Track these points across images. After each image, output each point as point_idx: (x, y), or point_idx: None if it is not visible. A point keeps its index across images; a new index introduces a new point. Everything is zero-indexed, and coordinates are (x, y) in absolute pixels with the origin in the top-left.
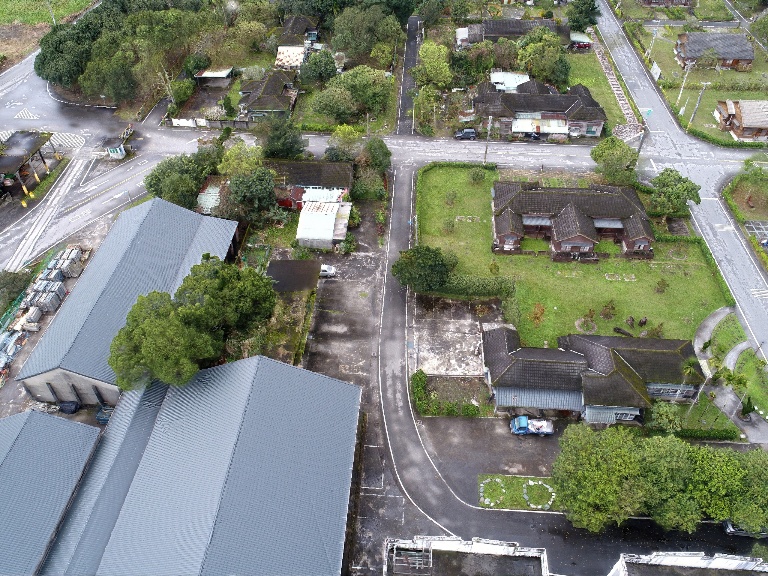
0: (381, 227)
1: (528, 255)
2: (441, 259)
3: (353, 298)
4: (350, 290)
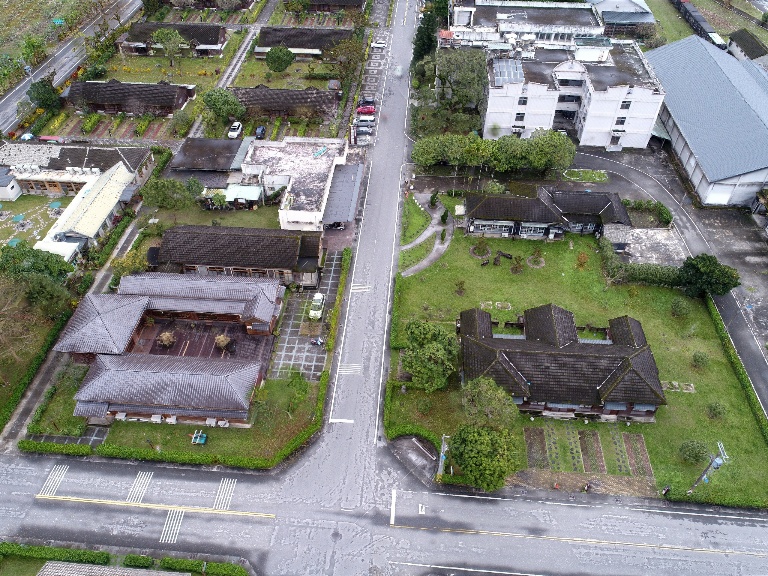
0: None
1: (594, 331)
2: (695, 260)
3: (759, 285)
4: (767, 293)
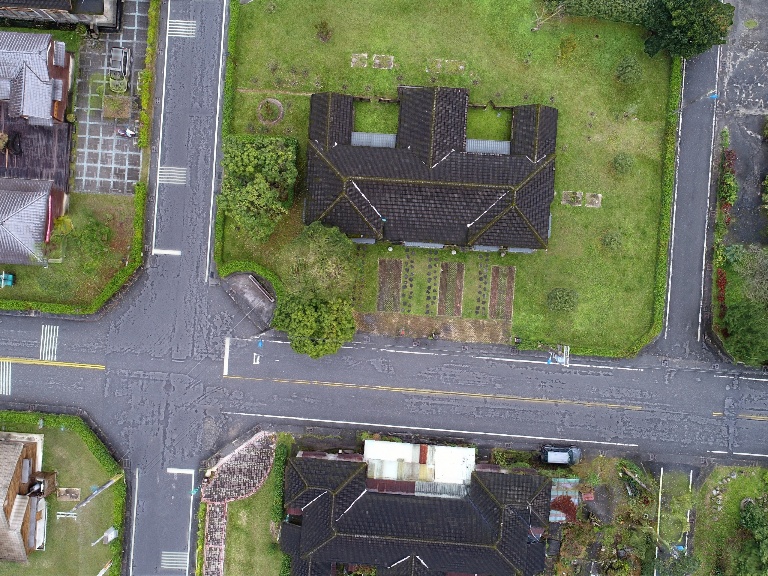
0: (730, 165)
1: (499, 108)
2: (672, 0)
3: (766, 15)
4: None
